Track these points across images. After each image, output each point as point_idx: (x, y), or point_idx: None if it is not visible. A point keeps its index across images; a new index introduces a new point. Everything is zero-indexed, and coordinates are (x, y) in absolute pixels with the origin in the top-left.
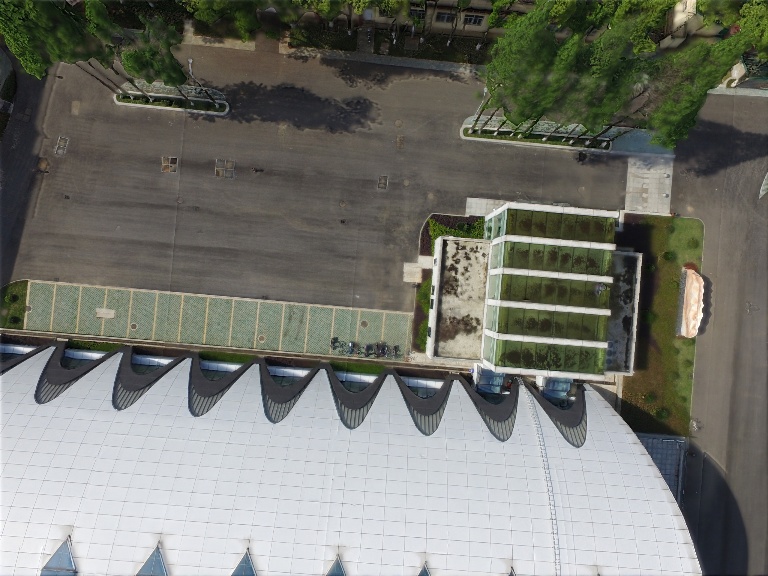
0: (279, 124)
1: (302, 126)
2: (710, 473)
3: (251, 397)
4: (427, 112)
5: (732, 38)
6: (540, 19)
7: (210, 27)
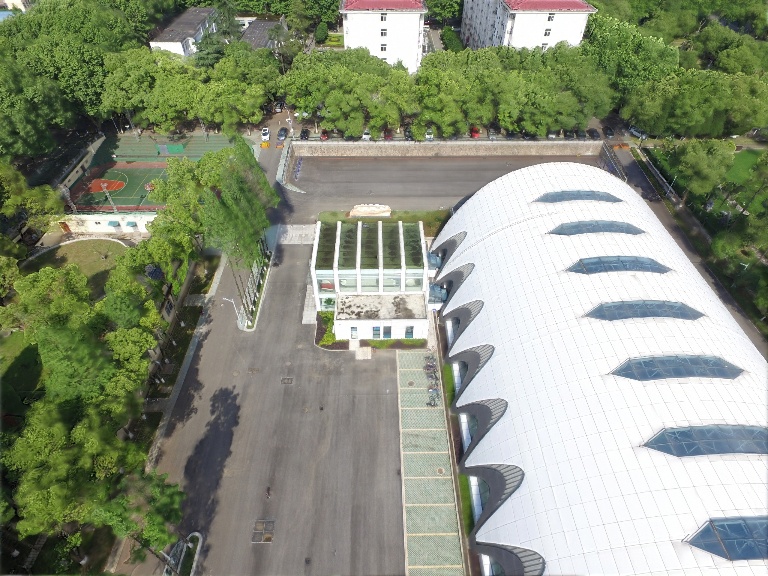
0: (221, 476)
1: (227, 453)
2: None
3: (493, 438)
4: (229, 354)
5: (236, 144)
6: (213, 195)
7: (93, 568)
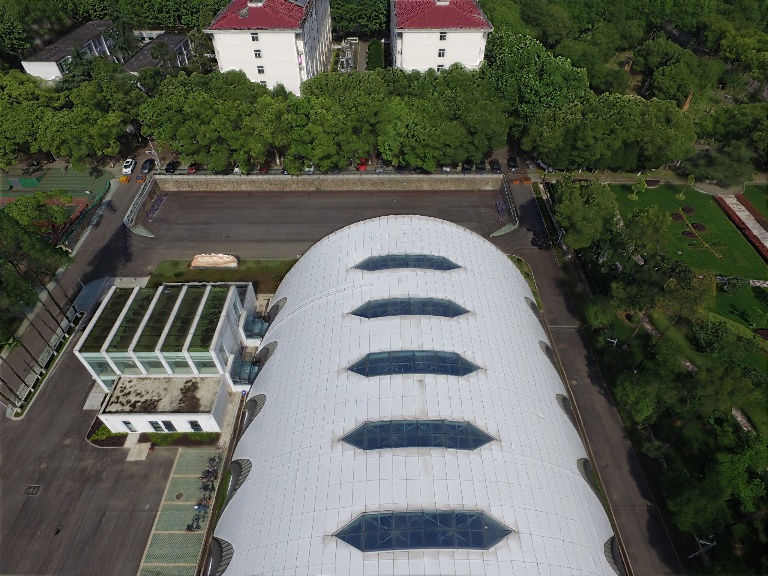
0: None
1: None
2: None
3: None
4: None
5: None
6: None
7: None
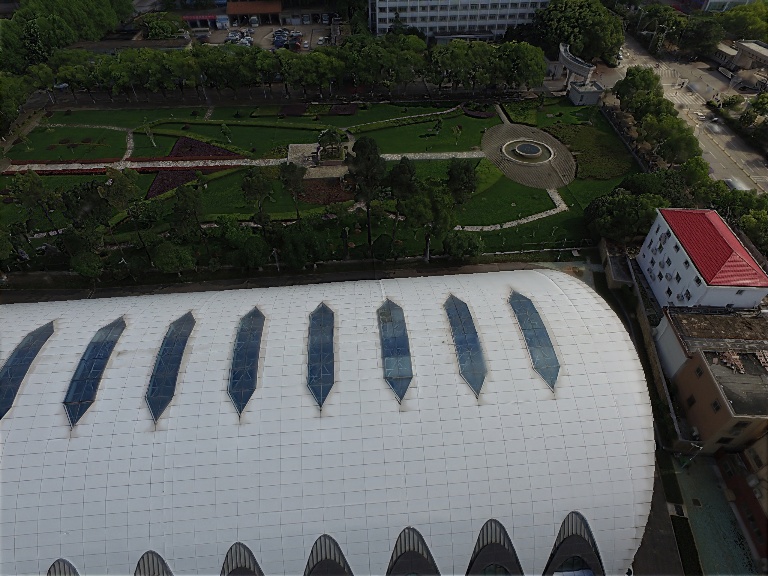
0: None
1: None
2: None
3: (275, 569)
4: None
5: None
6: None
7: None
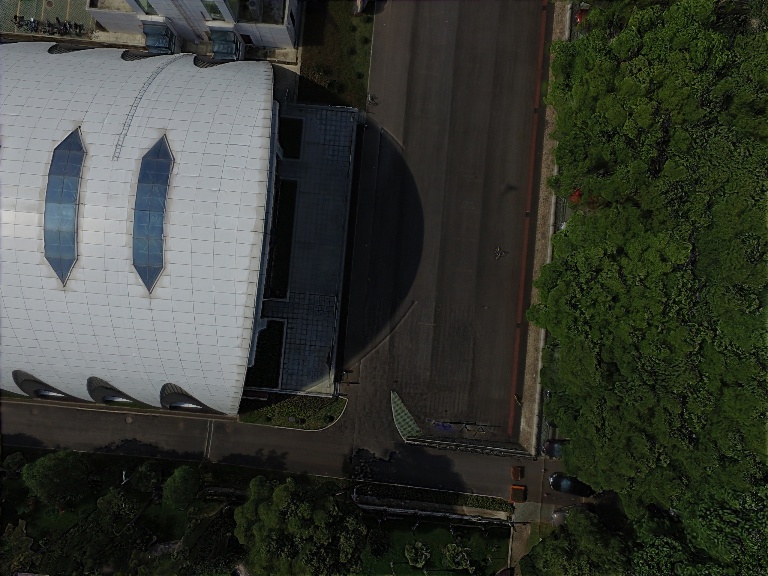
0: None
1: None
2: (387, 148)
3: None
4: None
5: None
6: None
7: None
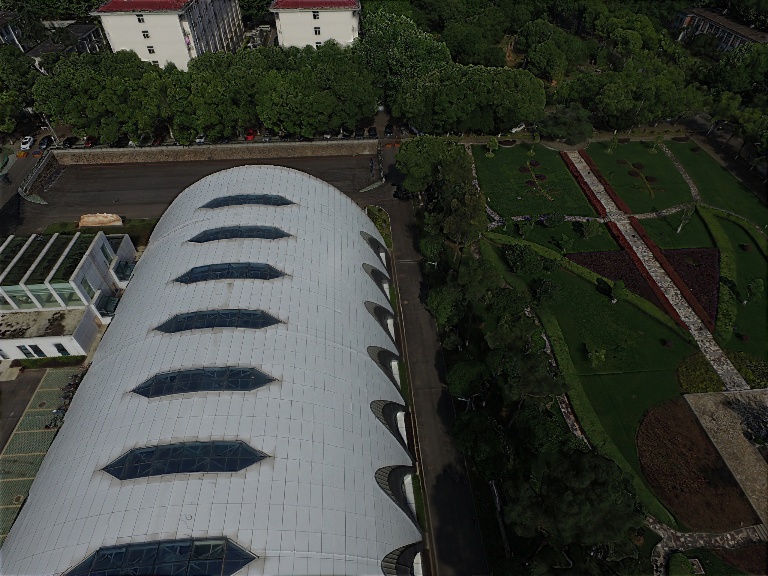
0: None
1: None
2: None
3: None
4: None
5: None
6: None
7: None
